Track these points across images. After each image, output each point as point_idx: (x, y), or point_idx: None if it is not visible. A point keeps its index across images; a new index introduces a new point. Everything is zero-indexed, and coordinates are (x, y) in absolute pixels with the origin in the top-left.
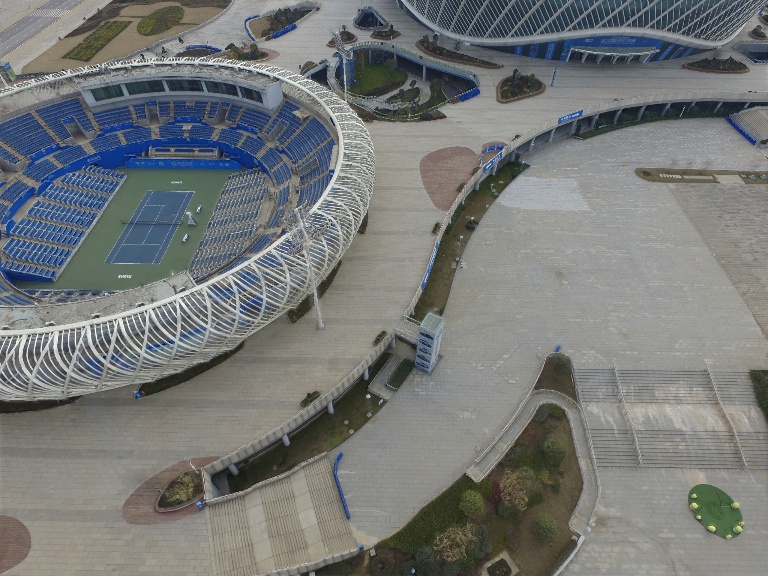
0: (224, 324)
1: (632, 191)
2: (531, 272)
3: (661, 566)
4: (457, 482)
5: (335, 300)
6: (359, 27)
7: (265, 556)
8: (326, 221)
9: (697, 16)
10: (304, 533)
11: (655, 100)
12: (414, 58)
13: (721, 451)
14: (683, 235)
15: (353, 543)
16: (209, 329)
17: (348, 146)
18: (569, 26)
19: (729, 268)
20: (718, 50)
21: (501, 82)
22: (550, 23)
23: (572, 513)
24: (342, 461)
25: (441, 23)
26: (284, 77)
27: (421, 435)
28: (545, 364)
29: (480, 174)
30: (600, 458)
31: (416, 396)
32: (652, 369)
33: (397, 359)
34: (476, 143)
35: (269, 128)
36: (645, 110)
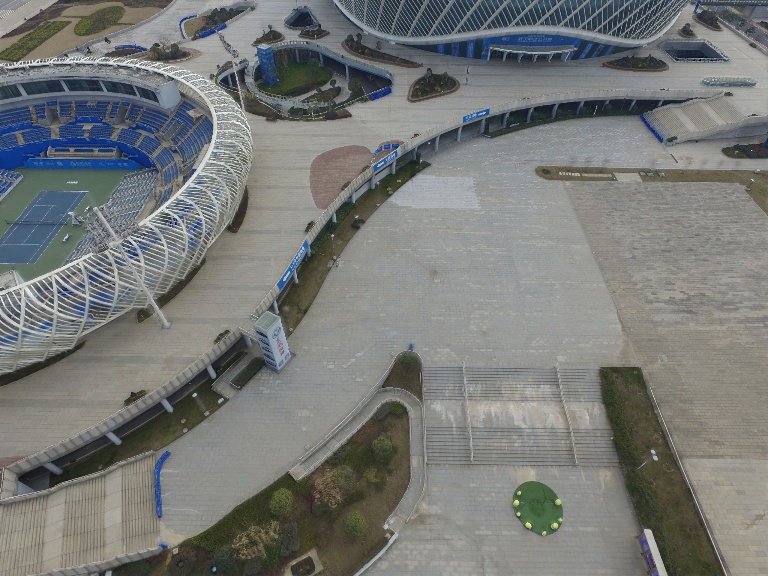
0: (40, 323)
1: (527, 189)
2: (405, 270)
3: (470, 563)
4: (278, 480)
5: (188, 299)
6: (289, 26)
7: (53, 555)
8: (170, 220)
9: (610, 14)
10: (105, 532)
11: (566, 98)
12: (336, 57)
13: (556, 448)
14: (567, 233)
15: (158, 542)
16: (21, 328)
17: (219, 145)
18: (484, 25)
19: (605, 266)
20: (643, 48)
21: (416, 81)
22: (465, 22)
23: (393, 511)
24: (168, 460)
25: (368, 22)
26: (179, 76)
27: (254, 434)
28: (396, 362)
29: (370, 173)
30: (434, 456)
31: (259, 395)
32: (502, 367)
33: (250, 358)
34: (374, 142)
35: (166, 128)
36: (560, 108)
